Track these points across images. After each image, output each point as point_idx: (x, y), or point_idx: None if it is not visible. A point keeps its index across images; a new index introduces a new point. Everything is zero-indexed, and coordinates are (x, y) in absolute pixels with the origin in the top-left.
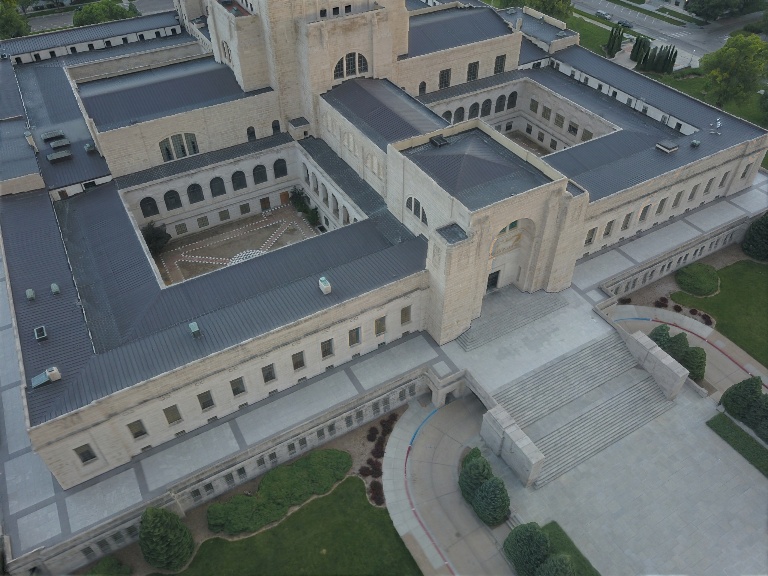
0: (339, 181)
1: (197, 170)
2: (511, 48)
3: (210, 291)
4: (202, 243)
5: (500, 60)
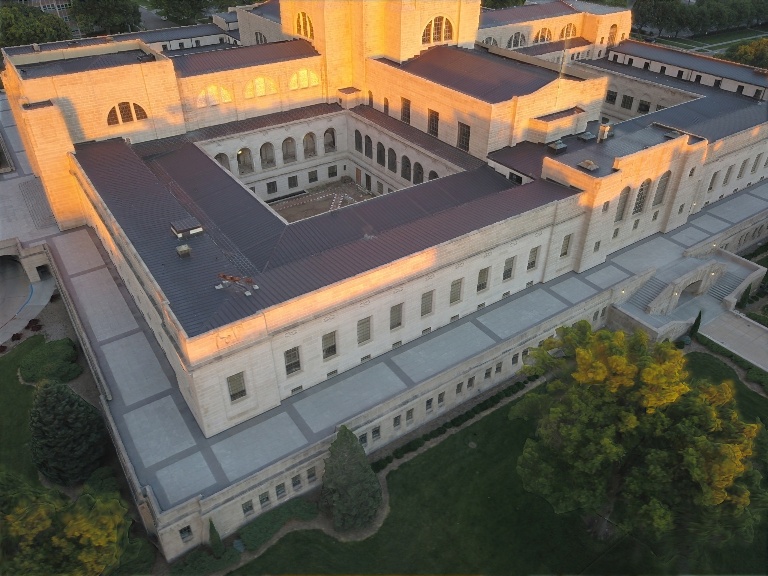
0: None
1: None
2: (477, 122)
3: None
4: None
5: (467, 131)
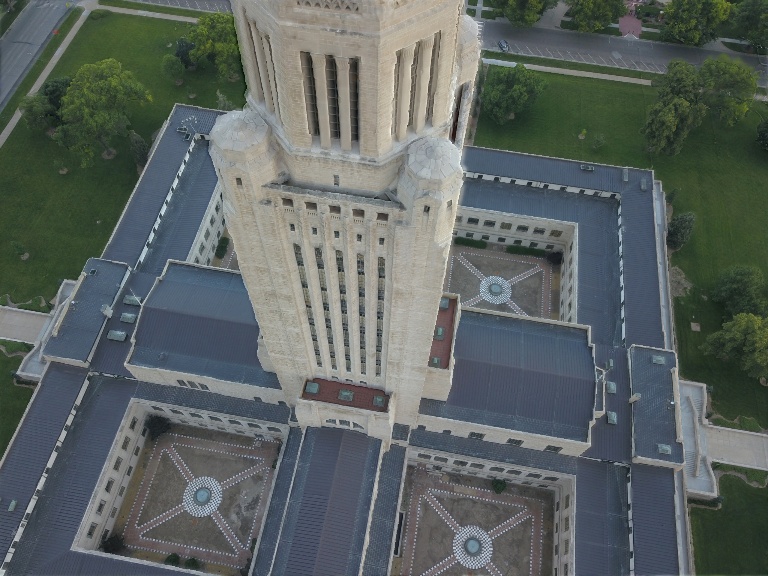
0: (273, 512)
1: (196, 410)
2: (572, 447)
3: (95, 575)
4: (193, 442)
5: None
